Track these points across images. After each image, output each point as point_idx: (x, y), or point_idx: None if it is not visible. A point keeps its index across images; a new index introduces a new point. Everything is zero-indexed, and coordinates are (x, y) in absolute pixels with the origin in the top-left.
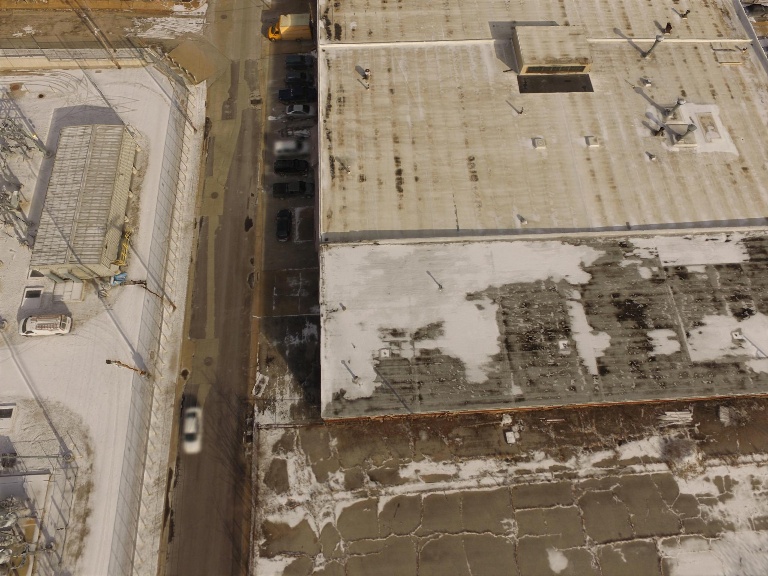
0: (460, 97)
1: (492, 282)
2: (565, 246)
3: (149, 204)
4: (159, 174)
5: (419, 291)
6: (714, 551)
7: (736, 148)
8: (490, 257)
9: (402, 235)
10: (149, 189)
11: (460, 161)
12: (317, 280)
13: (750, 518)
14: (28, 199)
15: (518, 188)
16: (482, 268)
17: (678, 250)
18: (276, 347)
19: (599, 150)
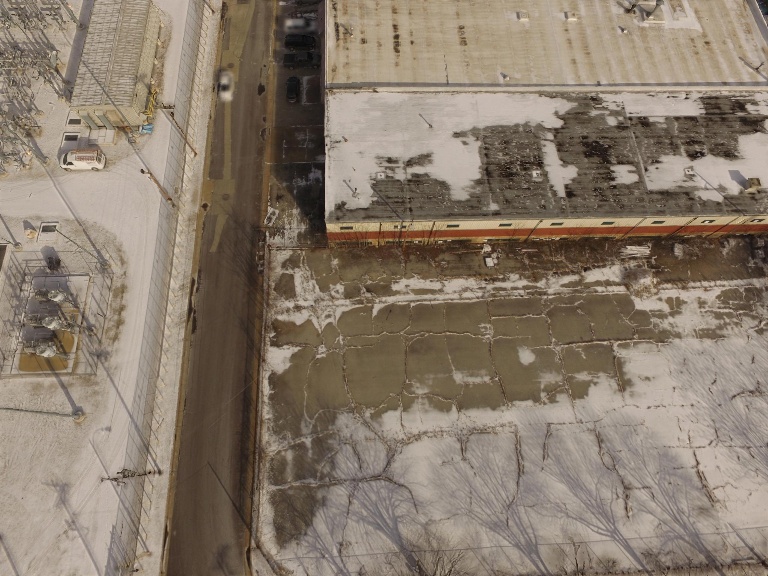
0: None
1: (476, 124)
2: (542, 98)
3: (172, 70)
4: (181, 46)
5: (412, 129)
6: (662, 353)
7: (700, 26)
8: (475, 105)
9: (398, 86)
10: (172, 58)
11: (451, 29)
12: (322, 135)
13: (695, 329)
14: (64, 63)
15: (502, 52)
16: (468, 113)
17: (642, 104)
18: (285, 187)
19: (576, 23)
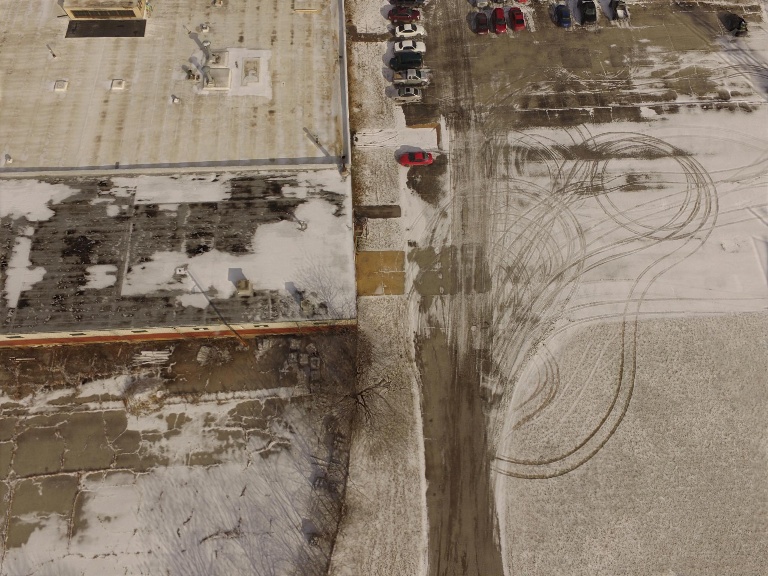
0: (1, 41)
1: None
2: (40, 184)
3: None
4: None
5: None
6: (137, 485)
7: (272, 92)
8: None
9: None
10: None
11: None
12: None
13: (188, 454)
14: None
15: (19, 129)
16: None
17: (158, 189)
18: None
19: (122, 93)
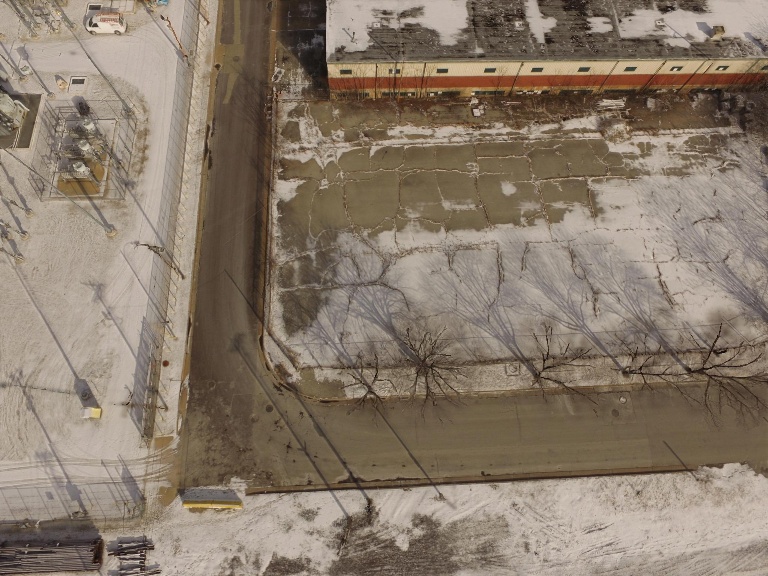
0: None
1: None
2: None
3: None
4: None
5: None
6: (632, 187)
7: None
8: None
9: None
10: None
11: None
12: (324, 6)
13: (663, 168)
14: None
15: None
16: None
17: None
18: (290, 50)
19: None
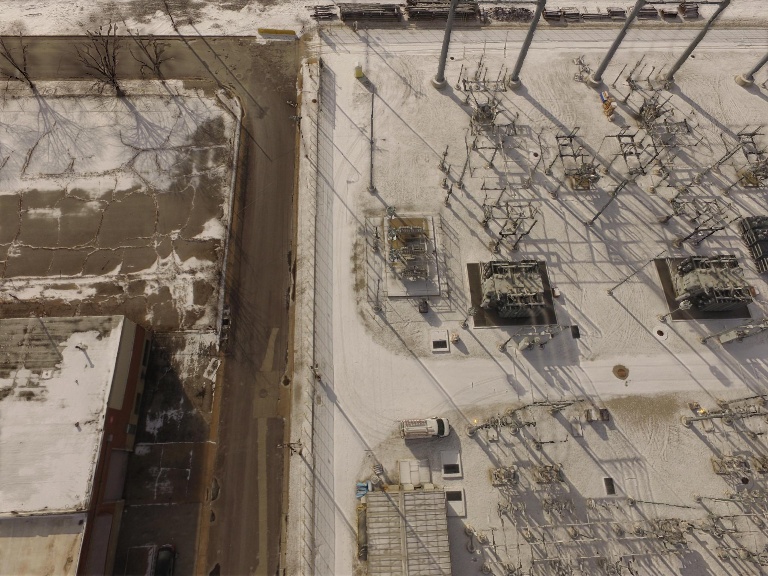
0: None
1: None
2: None
3: None
4: None
5: None
6: None
7: None
8: None
9: None
10: None
11: None
12: (135, 488)
13: None
14: None
15: None
16: None
17: None
18: None
19: None
